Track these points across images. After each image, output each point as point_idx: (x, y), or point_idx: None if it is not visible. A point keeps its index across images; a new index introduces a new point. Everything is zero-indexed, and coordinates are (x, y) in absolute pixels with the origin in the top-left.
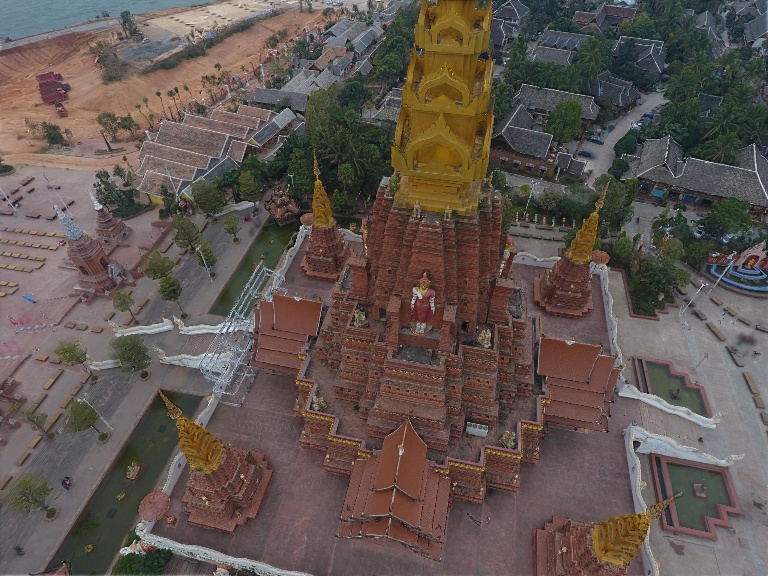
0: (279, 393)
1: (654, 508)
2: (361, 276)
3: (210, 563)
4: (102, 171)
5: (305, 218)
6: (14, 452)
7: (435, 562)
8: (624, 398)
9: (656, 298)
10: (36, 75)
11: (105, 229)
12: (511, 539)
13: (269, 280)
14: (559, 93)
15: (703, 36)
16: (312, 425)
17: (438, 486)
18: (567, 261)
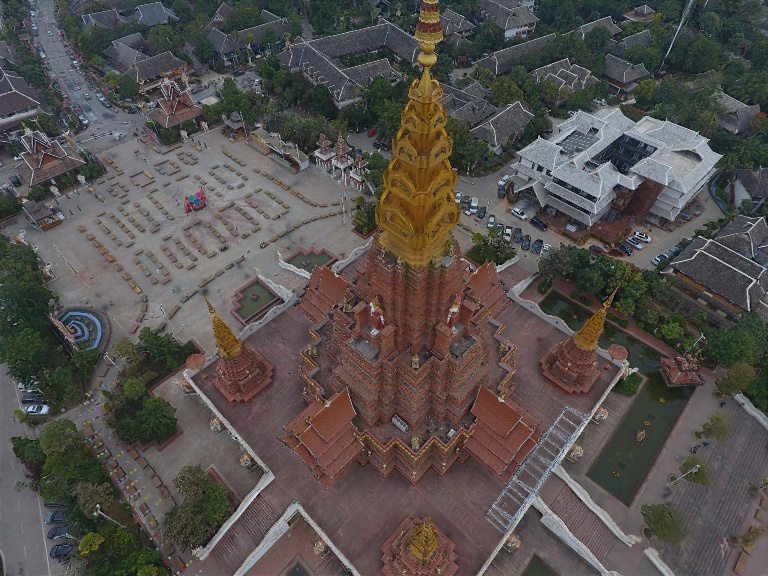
0: None
1: None
2: None
3: None
4: None
5: None
6: (767, 547)
7: None
8: None
9: None
10: None
11: None
12: None
13: None
14: None
15: None
16: None
17: None
18: None
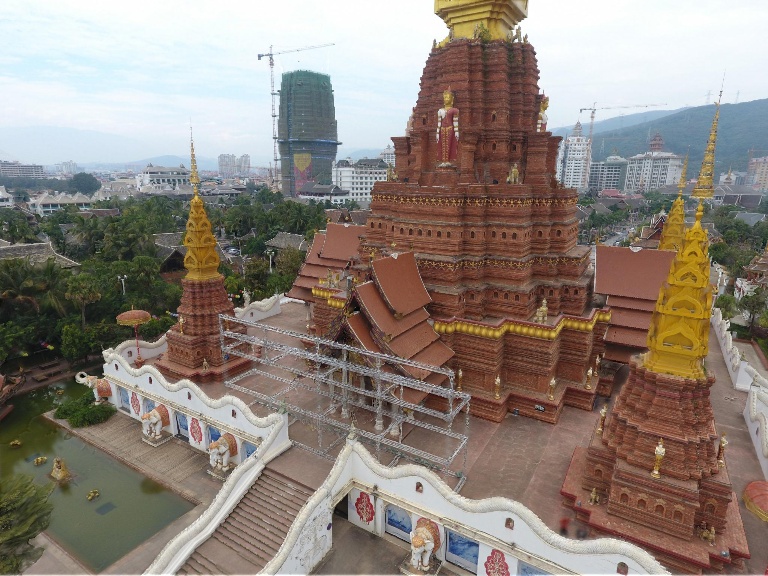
0: None
1: (682, 178)
2: (471, 153)
3: None
4: None
5: (132, 314)
6: None
7: None
8: None
9: None
10: None
11: None
12: None
13: (125, 459)
14: (162, 235)
15: None
16: (553, 361)
17: None
18: None
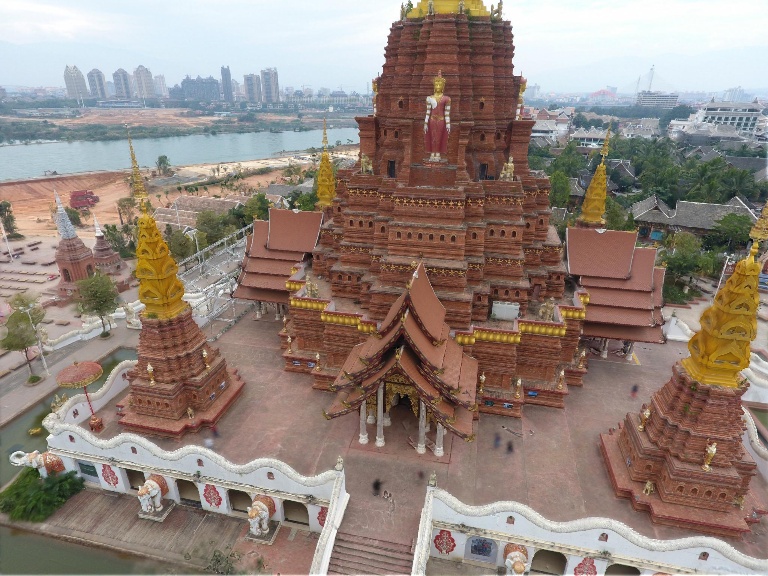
0: (263, 333)
1: (760, 217)
2: (369, 139)
3: (136, 496)
4: (111, 227)
5: None
6: None
7: (463, 470)
8: (674, 341)
9: (681, 292)
10: (71, 192)
11: (100, 257)
12: (567, 450)
13: None
14: None
15: (663, 152)
16: (301, 326)
17: (462, 359)
18: (580, 224)
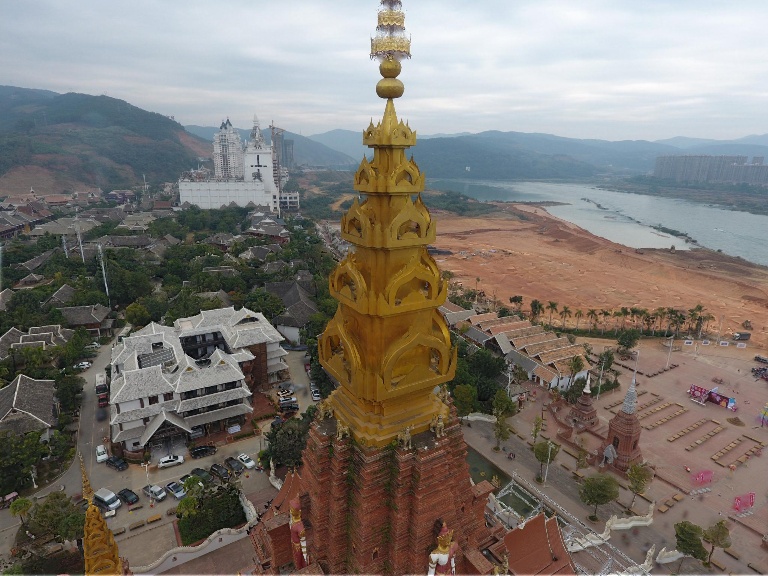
0: None
1: None
2: None
3: None
4: None
5: None
6: None
7: None
8: None
9: None
10: None
11: None
12: None
13: None
14: None
15: None
16: None
17: None
18: None
